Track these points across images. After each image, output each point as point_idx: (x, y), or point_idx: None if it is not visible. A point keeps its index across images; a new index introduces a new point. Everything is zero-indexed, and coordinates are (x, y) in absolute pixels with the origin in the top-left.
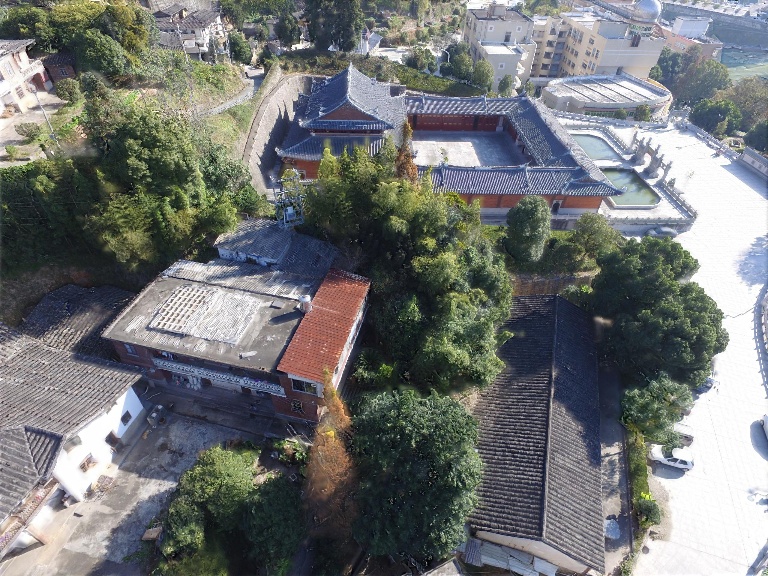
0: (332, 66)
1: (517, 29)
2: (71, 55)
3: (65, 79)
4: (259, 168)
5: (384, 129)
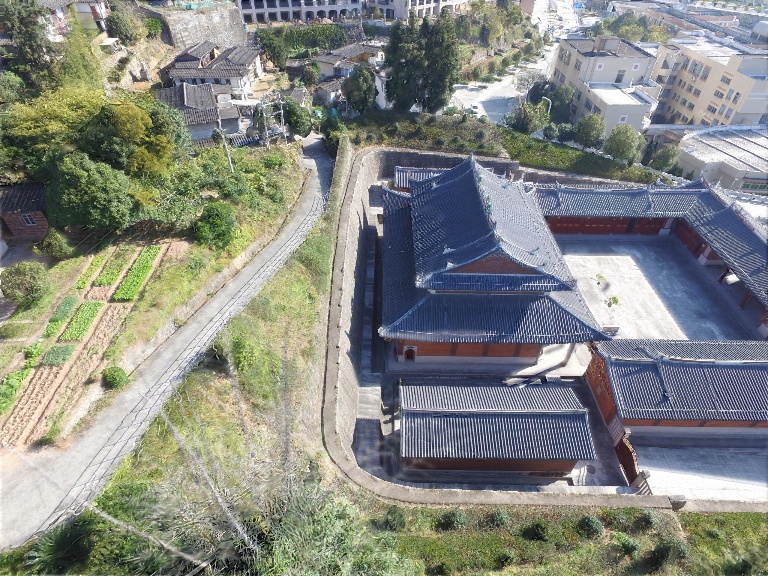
0: (417, 135)
1: (633, 67)
2: (41, 190)
3: (16, 265)
4: (349, 357)
5: (554, 290)
